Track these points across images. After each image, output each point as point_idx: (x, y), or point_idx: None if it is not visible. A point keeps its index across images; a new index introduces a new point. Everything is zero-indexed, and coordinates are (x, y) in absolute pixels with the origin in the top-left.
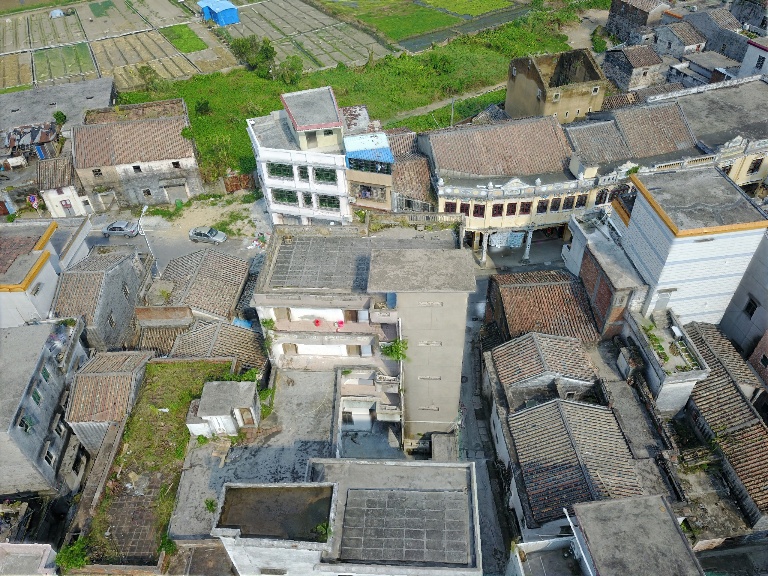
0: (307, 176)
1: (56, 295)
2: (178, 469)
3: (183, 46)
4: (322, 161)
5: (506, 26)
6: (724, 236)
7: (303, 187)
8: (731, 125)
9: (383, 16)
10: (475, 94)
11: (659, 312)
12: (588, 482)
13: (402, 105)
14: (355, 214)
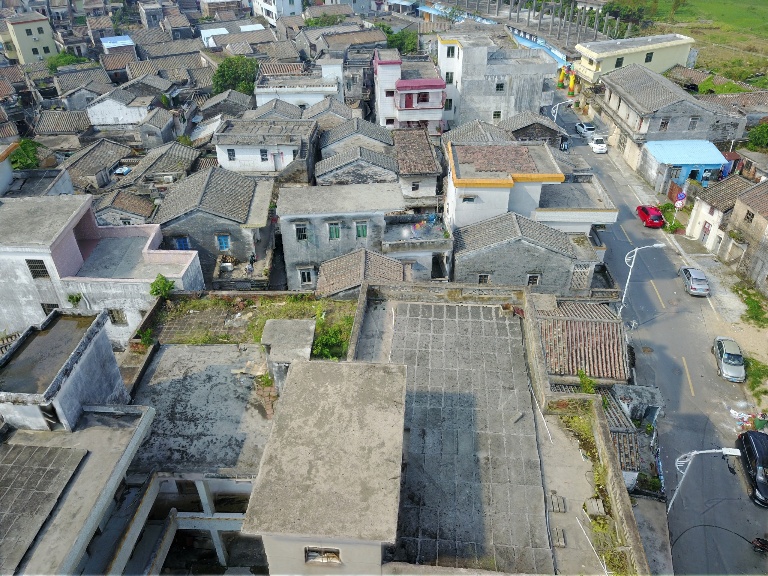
0: None
1: (485, 221)
2: (244, 342)
3: None
4: None
5: None
6: None
7: None
8: None
9: None
10: None
11: None
12: None
13: None
14: None
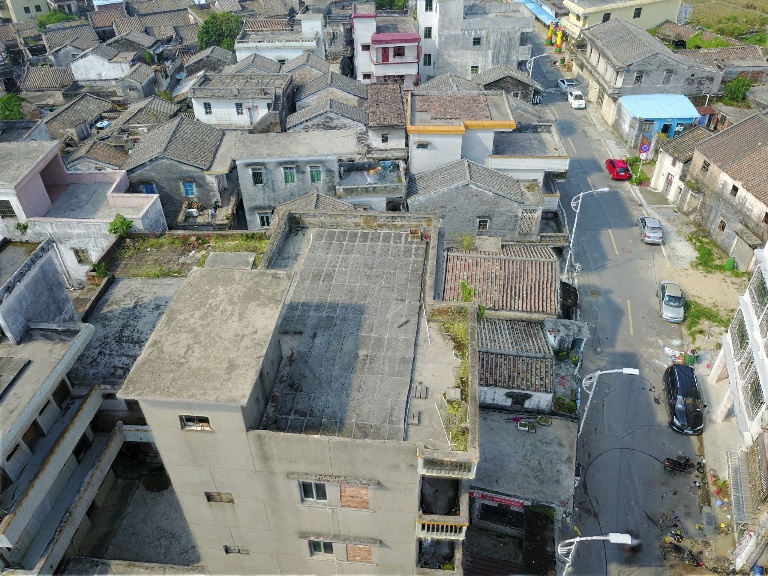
0: (767, 327)
1: (439, 168)
2: None
3: None
4: None
5: None
6: None
7: (759, 341)
8: None
9: None
10: None
11: None
12: None
13: None
14: (754, 446)
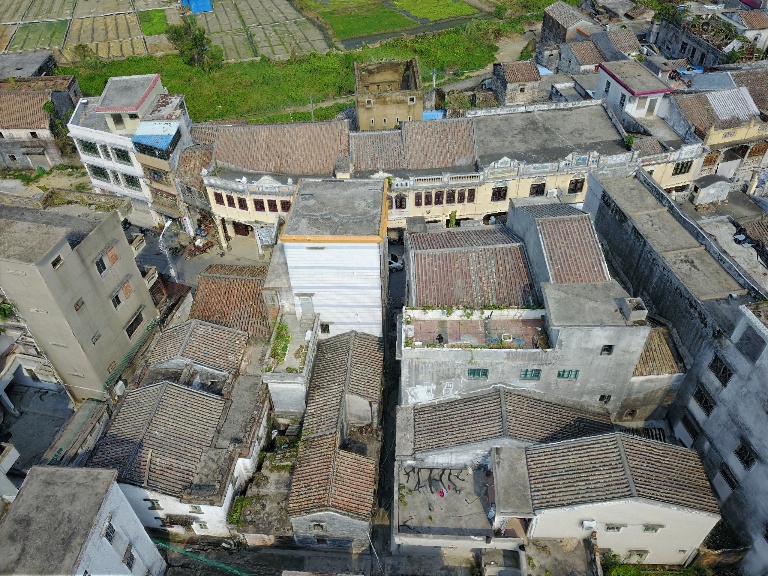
0: (109, 155)
1: None
2: None
3: (147, 29)
4: (117, 142)
5: (446, 32)
6: (339, 246)
7: (110, 165)
8: (529, 147)
9: (345, 14)
10: None
11: (309, 316)
12: (130, 457)
13: (295, 101)
14: (153, 195)
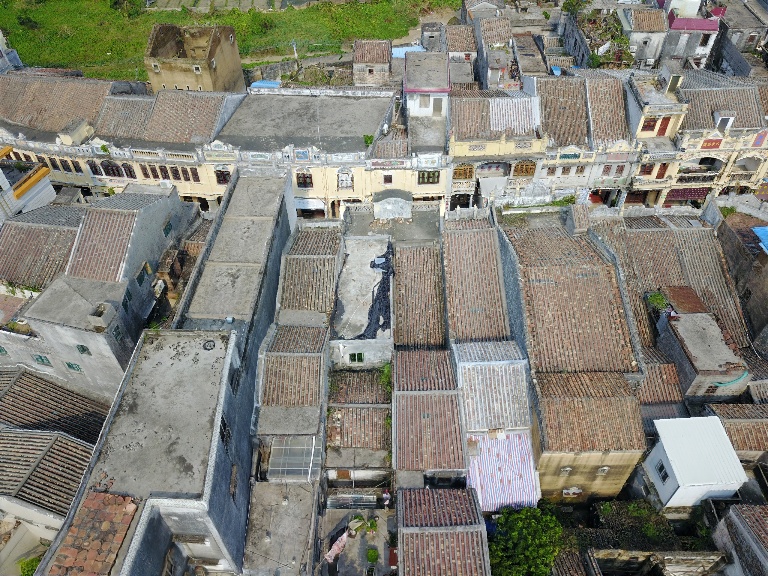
0: None
1: None
2: None
3: None
4: None
5: (380, 1)
6: None
7: None
8: (277, 133)
9: None
10: (254, 60)
11: None
12: None
13: None
14: None
